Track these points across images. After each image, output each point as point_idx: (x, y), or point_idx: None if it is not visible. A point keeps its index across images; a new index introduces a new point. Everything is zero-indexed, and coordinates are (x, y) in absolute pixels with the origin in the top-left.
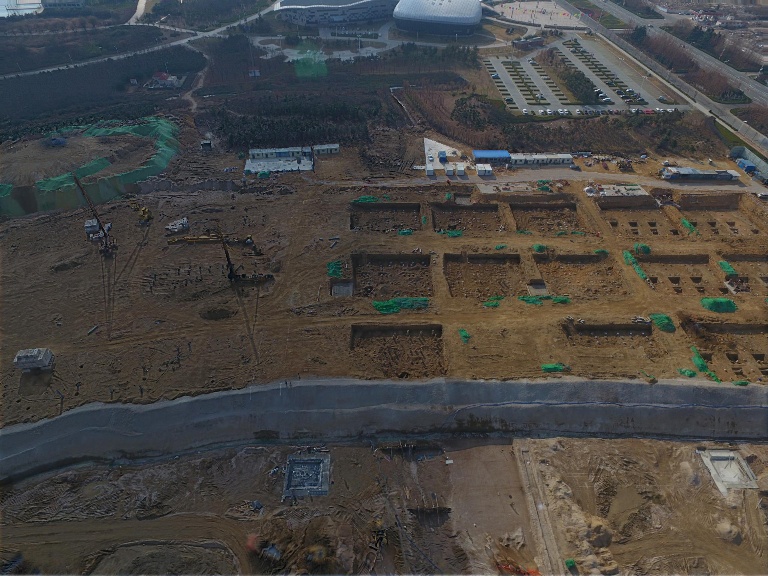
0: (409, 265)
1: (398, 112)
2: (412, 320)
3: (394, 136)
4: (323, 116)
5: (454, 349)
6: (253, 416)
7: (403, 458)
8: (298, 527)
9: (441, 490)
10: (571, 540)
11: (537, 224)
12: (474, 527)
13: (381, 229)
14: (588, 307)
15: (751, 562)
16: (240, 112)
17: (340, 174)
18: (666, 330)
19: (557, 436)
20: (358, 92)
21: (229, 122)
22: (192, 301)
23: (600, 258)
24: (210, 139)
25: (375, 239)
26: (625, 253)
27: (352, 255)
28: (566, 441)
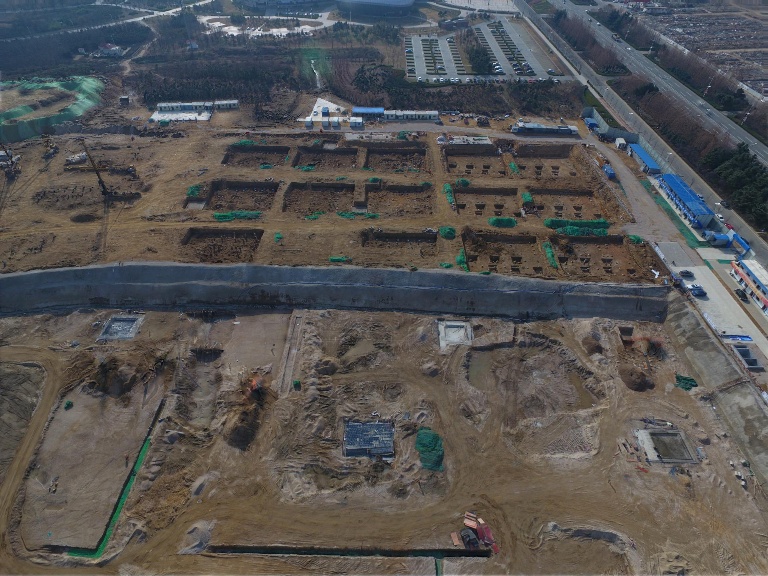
0: (260, 191)
1: (304, 77)
2: (241, 226)
3: (292, 96)
4: (236, 79)
5: (265, 246)
6: (89, 286)
7: (202, 320)
8: (100, 357)
9: (222, 340)
10: (303, 369)
11: (385, 164)
12: (236, 362)
13: (249, 165)
14: (391, 221)
15: (436, 387)
16: (165, 76)
17: (230, 123)
18: (446, 237)
19: (329, 308)
20: (278, 62)
21: (152, 83)
22: (68, 210)
23: (424, 189)
24: (130, 96)
25: (238, 171)
26: (445, 185)
27: (213, 181)
28: (334, 311)
